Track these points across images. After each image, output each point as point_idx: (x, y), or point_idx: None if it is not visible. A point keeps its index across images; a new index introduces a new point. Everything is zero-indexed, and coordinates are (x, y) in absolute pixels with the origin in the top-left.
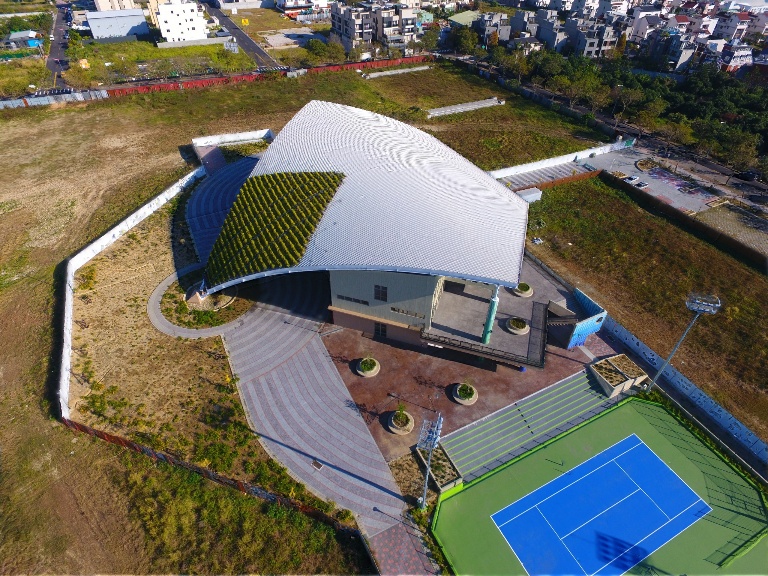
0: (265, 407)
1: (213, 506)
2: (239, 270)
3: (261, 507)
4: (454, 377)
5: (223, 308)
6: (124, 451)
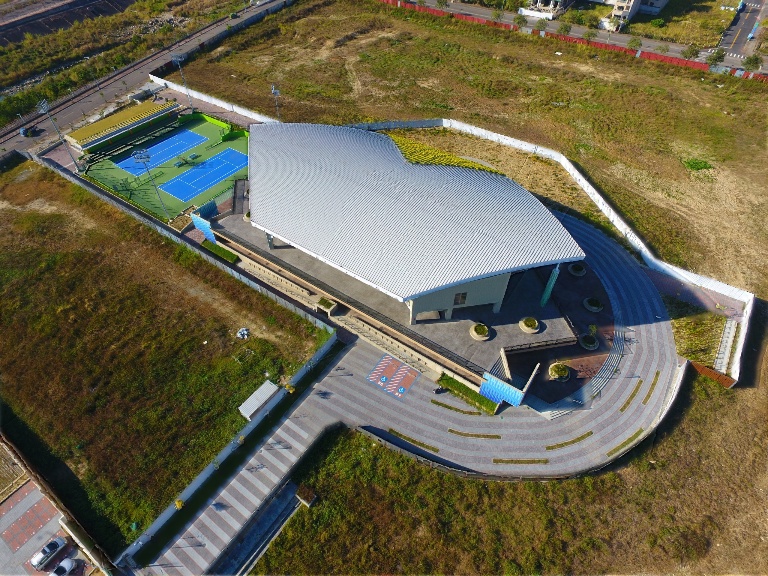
0: None
1: None
2: None
3: None
4: None
5: None
6: None
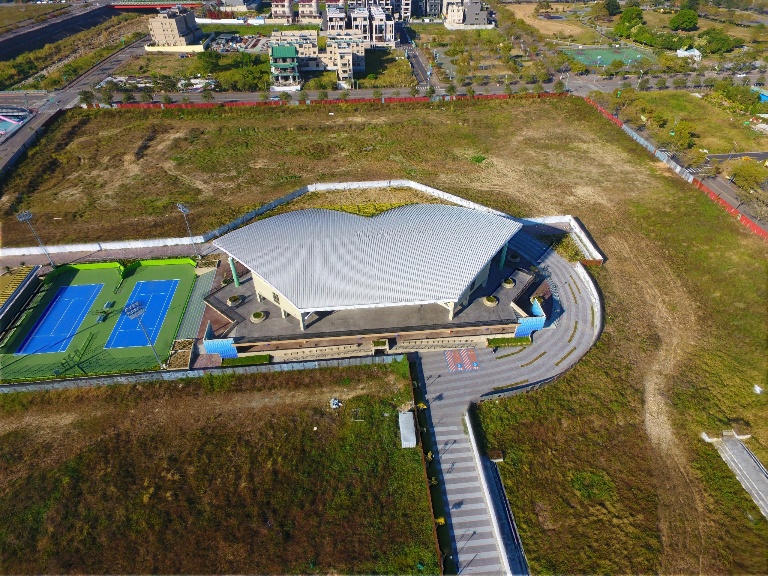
0: None
1: None
2: None
3: None
4: None
5: None
6: None
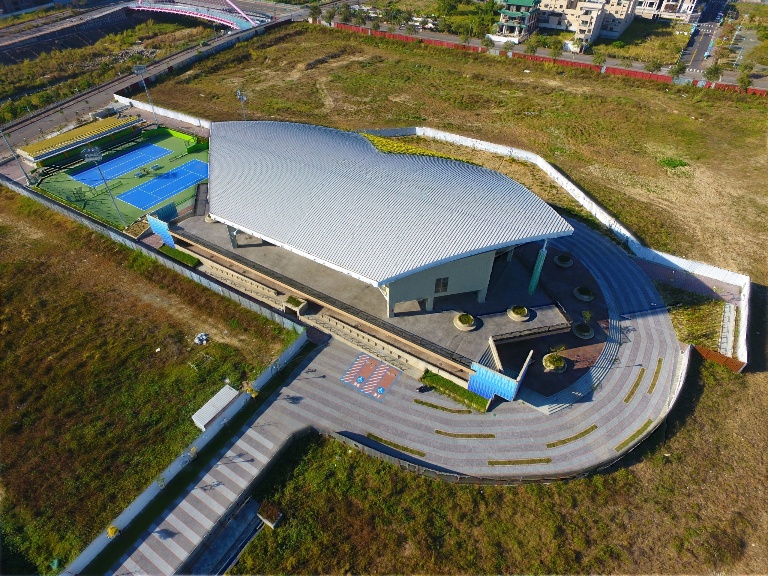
0: None
1: None
2: None
3: None
4: None
5: None
6: None
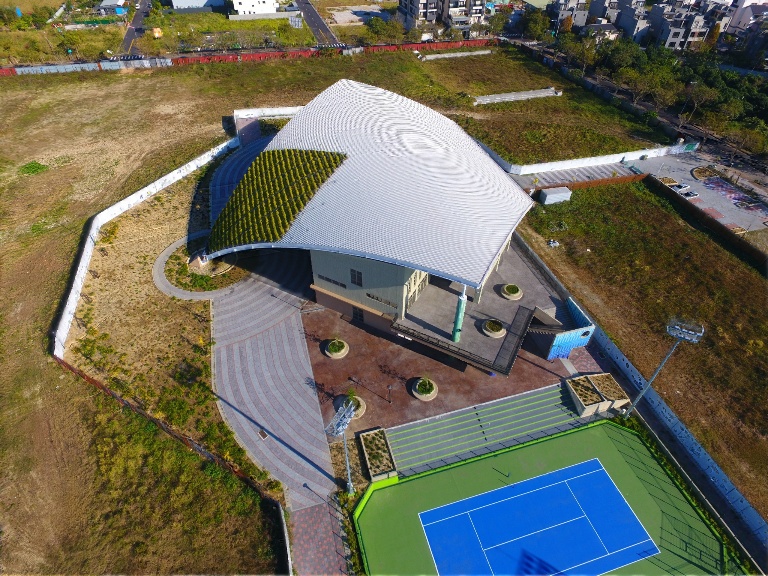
0: (231, 373)
1: (159, 455)
2: (232, 240)
3: (201, 464)
4: (419, 371)
5: (219, 275)
6: (99, 393)
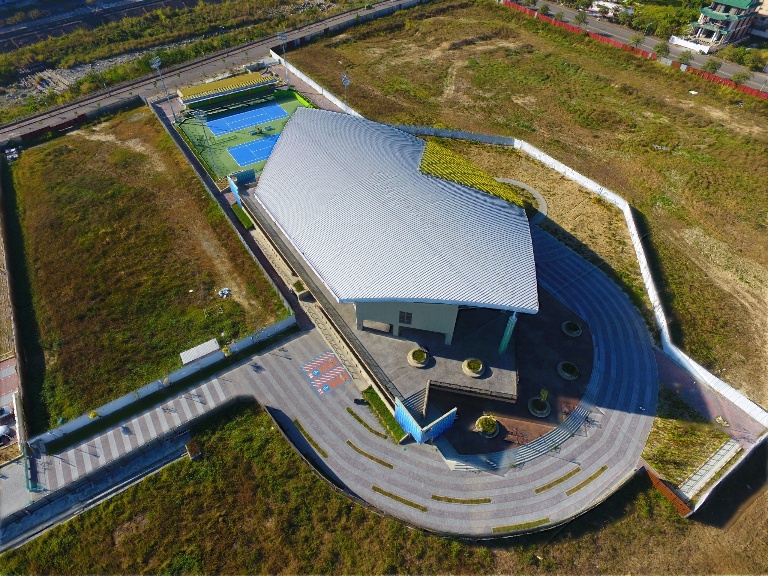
0: None
1: None
2: None
3: None
4: None
5: None
6: None
